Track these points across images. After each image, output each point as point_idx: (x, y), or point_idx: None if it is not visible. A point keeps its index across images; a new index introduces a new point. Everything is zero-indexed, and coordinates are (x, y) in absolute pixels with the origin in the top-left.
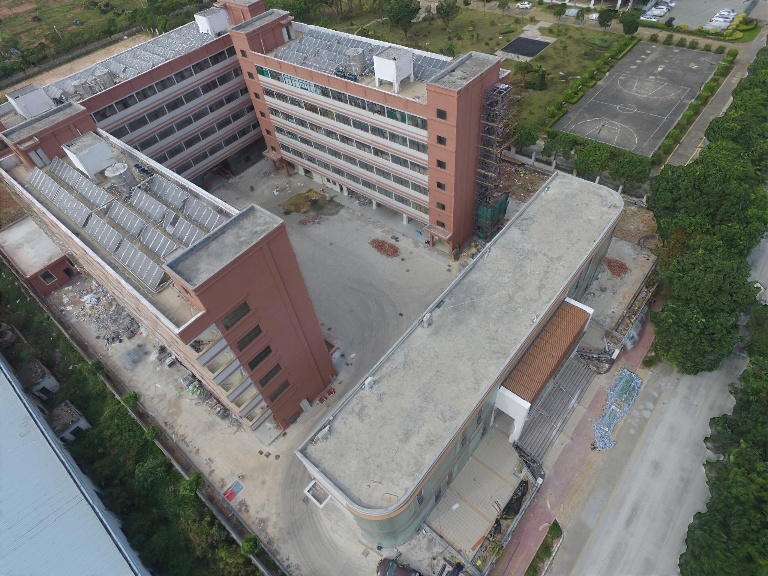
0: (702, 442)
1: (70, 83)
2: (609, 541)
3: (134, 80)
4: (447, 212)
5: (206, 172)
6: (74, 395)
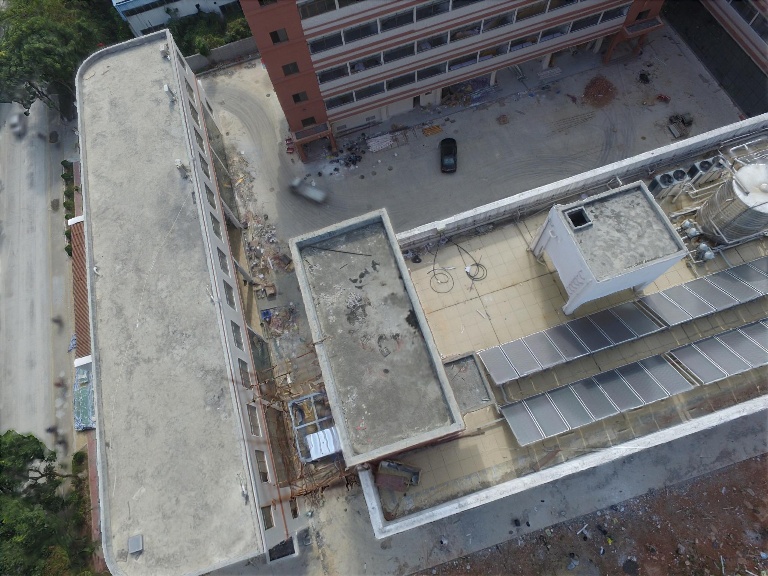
0: (5, 422)
1: None
2: (39, 281)
3: None
4: None
5: None
6: None
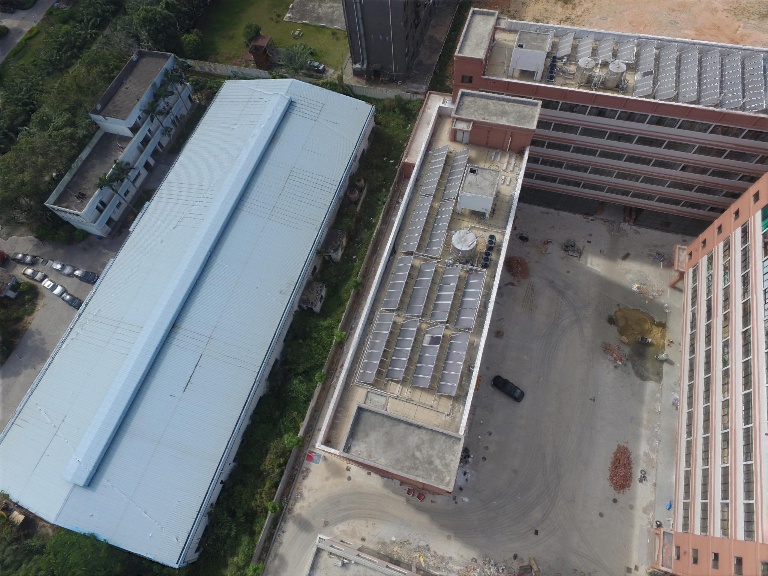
0: None
1: (589, 44)
2: None
3: (634, 101)
4: (691, 568)
5: (611, 202)
6: (332, 284)
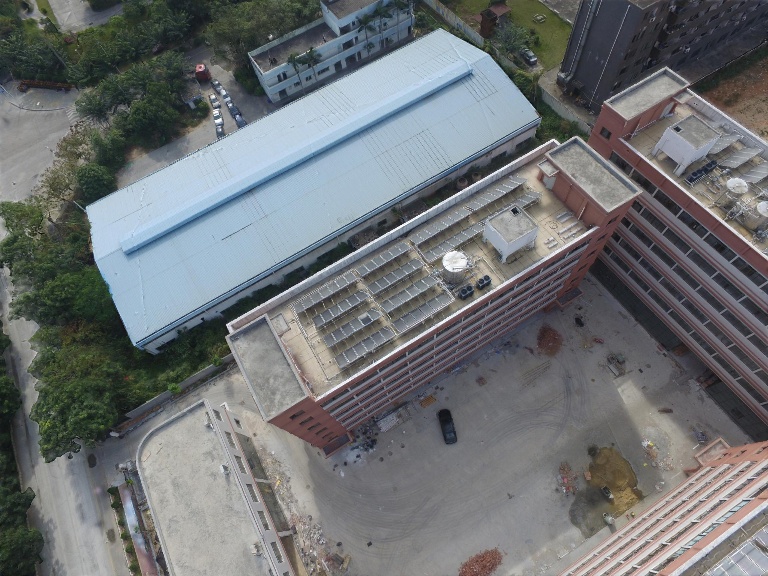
0: None
1: (767, 171)
2: None
3: (757, 254)
4: None
5: None
6: None
